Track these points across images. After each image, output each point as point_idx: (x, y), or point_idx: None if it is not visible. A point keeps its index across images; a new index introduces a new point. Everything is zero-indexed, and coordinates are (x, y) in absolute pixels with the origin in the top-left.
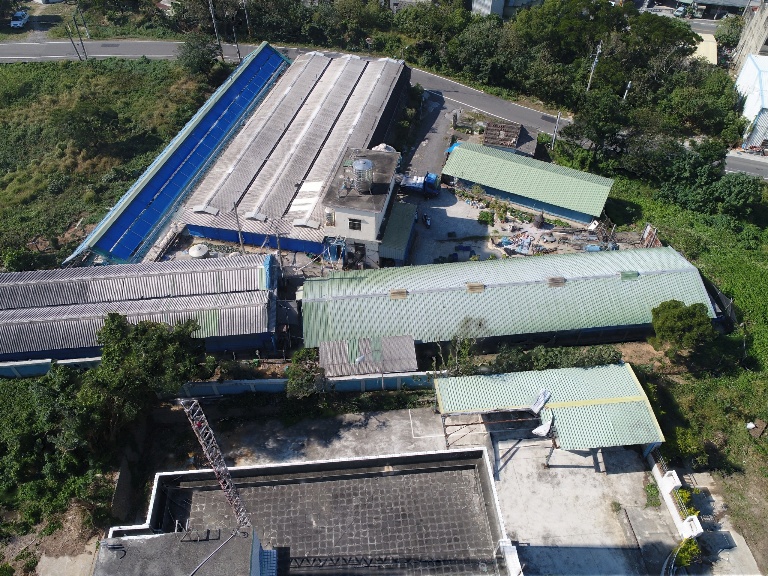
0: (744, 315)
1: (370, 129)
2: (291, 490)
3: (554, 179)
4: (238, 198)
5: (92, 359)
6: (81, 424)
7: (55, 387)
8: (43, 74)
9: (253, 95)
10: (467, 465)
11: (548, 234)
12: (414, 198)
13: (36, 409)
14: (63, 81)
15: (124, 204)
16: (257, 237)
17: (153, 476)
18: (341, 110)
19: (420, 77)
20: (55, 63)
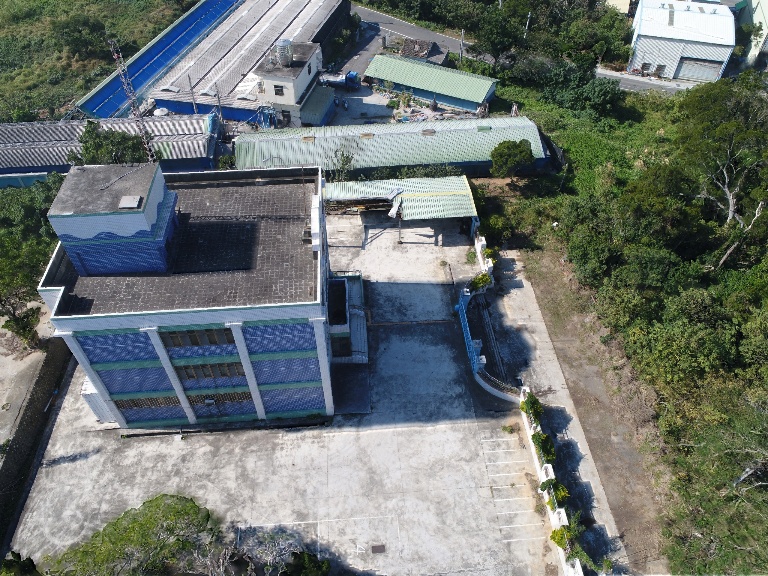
0: (574, 163)
1: (307, 39)
2: (196, 191)
3: (450, 77)
4: (196, 82)
5: None
6: None
7: (50, 184)
8: (45, 3)
9: (217, 17)
10: (309, 179)
11: (439, 115)
12: (339, 91)
13: (36, 202)
14: (62, 8)
15: (106, 81)
16: (209, 109)
17: None
18: (286, 27)
19: (362, 12)
20: None
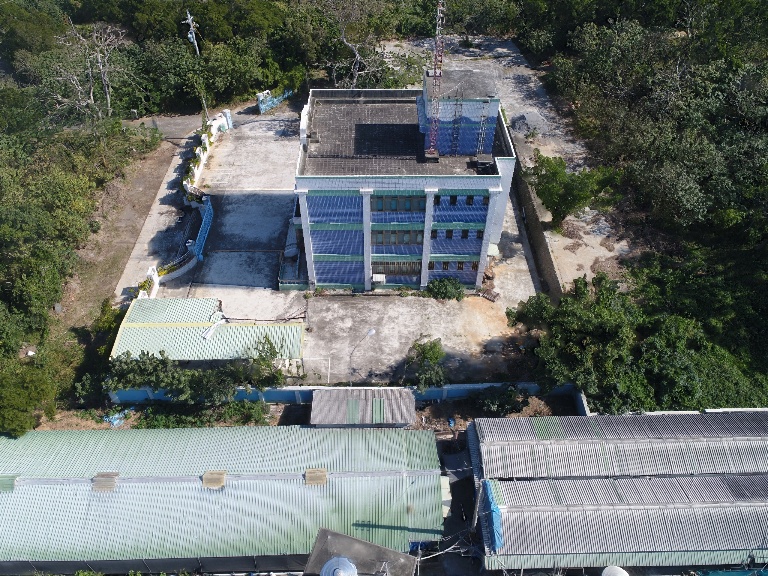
0: None
1: None
2: None
3: None
4: None
5: (662, 413)
6: None
7: None
8: None
9: None
10: None
11: None
12: None
13: None
14: None
15: None
16: None
17: None
18: None
19: None
20: None
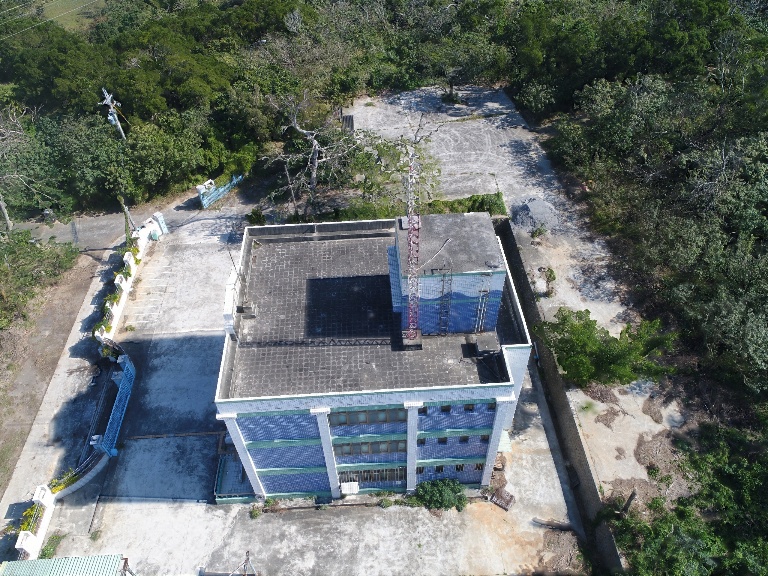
0: None
1: None
2: None
3: None
4: None
5: None
6: None
7: None
8: None
9: None
10: None
11: None
12: None
13: None
14: None
15: None
16: None
17: None
18: None
19: None
20: None
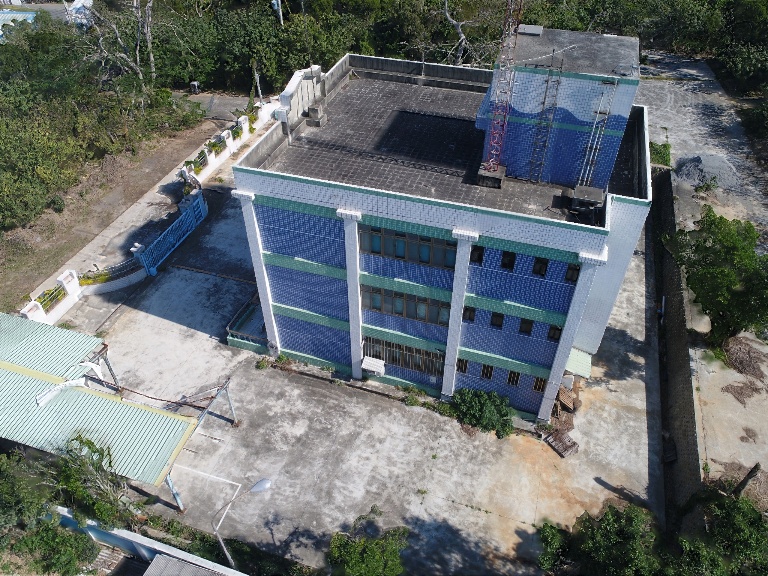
0: None
1: None
2: None
3: None
4: None
5: None
6: None
7: None
8: None
9: None
10: None
11: None
12: None
13: None
14: None
15: None
16: None
17: None
18: None
19: None
20: None
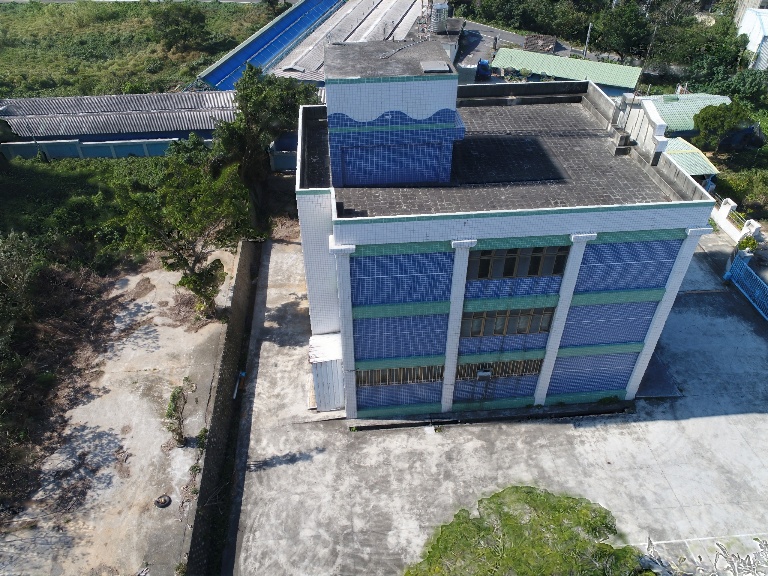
0: None
1: None
2: None
3: (591, 65)
4: (320, 64)
5: None
6: (228, 136)
7: (188, 145)
8: (128, 8)
9: (319, 15)
10: (576, 96)
11: None
12: None
13: None
14: None
15: (225, 57)
16: None
17: (274, 215)
18: (399, 22)
19: None
20: (137, 2)
